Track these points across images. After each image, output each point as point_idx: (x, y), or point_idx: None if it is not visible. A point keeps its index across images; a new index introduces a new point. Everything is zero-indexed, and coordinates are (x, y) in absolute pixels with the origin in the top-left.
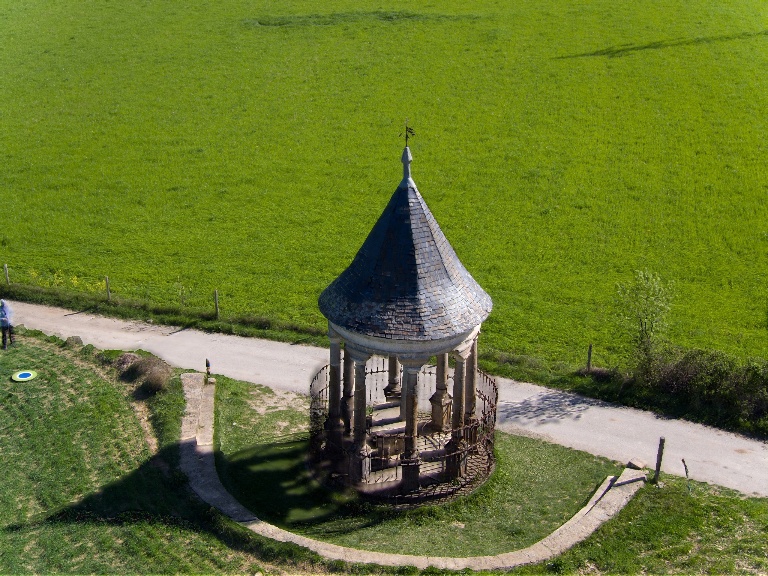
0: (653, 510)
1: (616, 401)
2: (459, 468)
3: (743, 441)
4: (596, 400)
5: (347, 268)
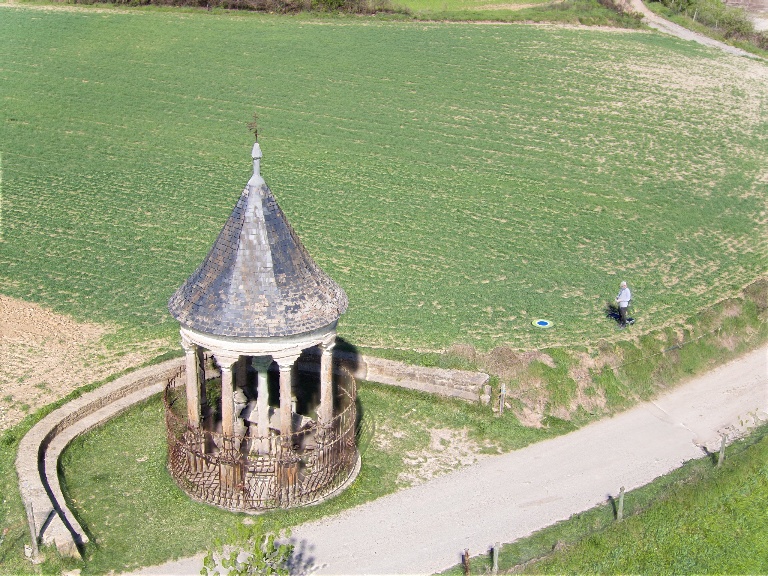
0: (5, 525)
1: None
2: None
3: None
4: None
5: None
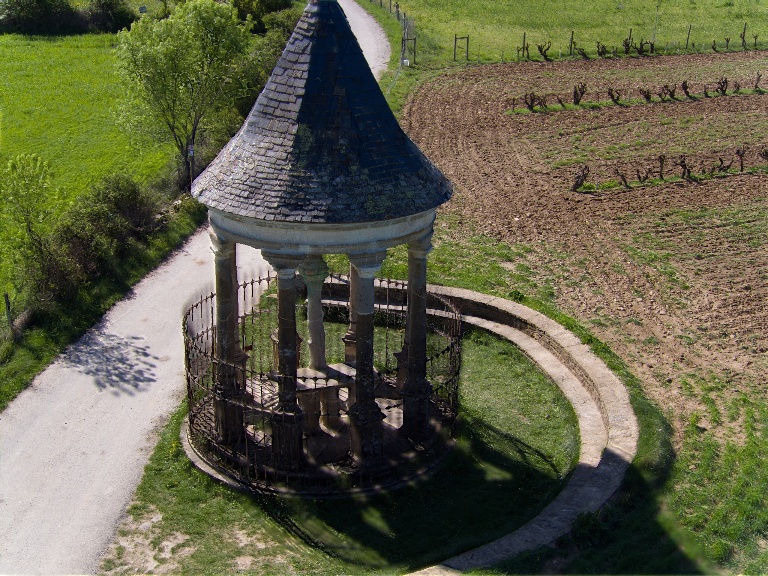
0: None
1: (94, 319)
2: None
3: (177, 262)
4: (90, 332)
5: (351, 153)
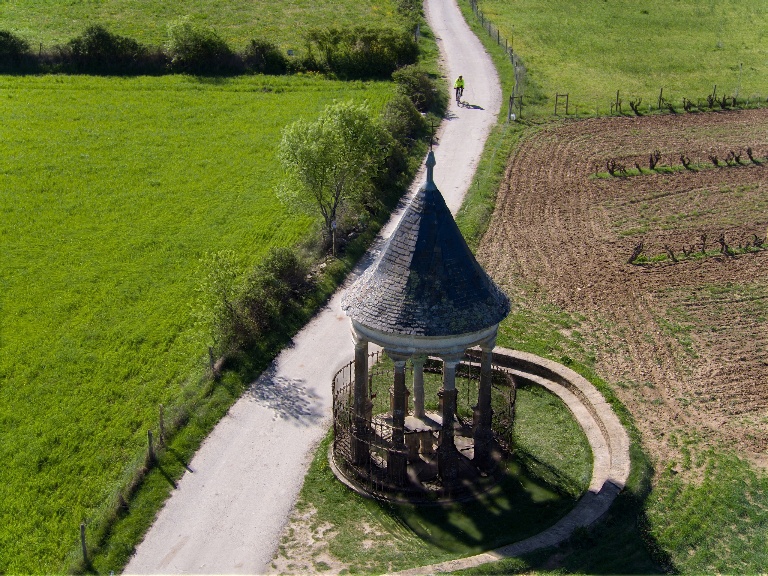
0: None
1: (267, 364)
2: (456, 406)
3: (323, 318)
4: (264, 374)
5: (443, 290)
